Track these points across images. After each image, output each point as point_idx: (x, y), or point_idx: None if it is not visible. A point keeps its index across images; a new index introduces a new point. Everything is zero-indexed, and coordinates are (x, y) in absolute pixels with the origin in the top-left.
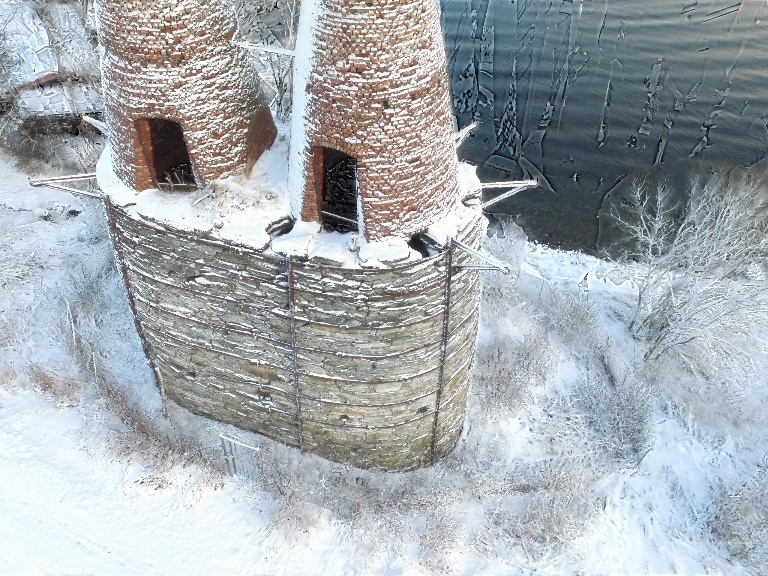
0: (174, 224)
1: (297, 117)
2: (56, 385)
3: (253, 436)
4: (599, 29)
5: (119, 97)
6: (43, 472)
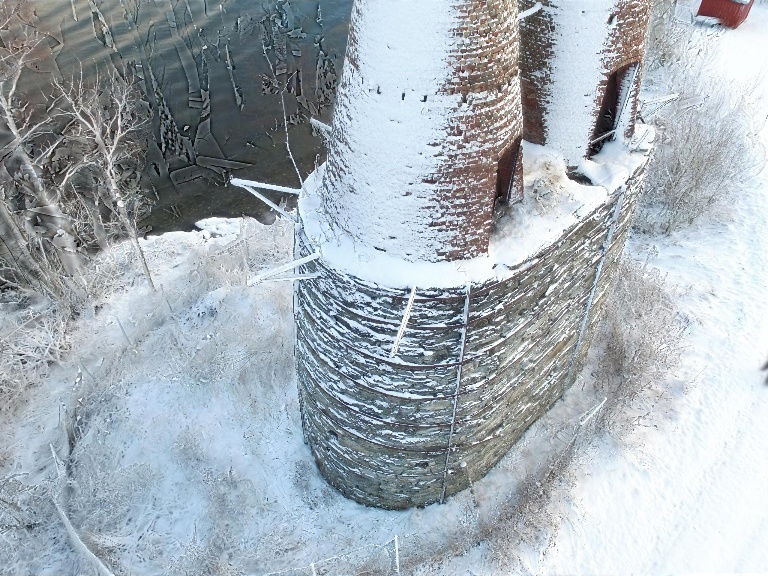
0: (548, 244)
1: (586, 60)
2: None
3: (532, 432)
4: (202, 1)
5: (483, 144)
6: None
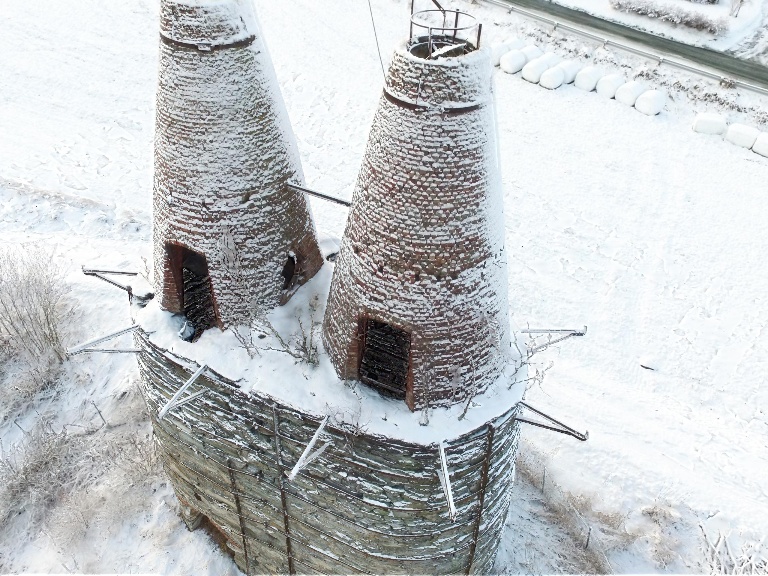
0: None
1: None
2: (596, 516)
3: None
4: None
5: None
6: (565, 436)
